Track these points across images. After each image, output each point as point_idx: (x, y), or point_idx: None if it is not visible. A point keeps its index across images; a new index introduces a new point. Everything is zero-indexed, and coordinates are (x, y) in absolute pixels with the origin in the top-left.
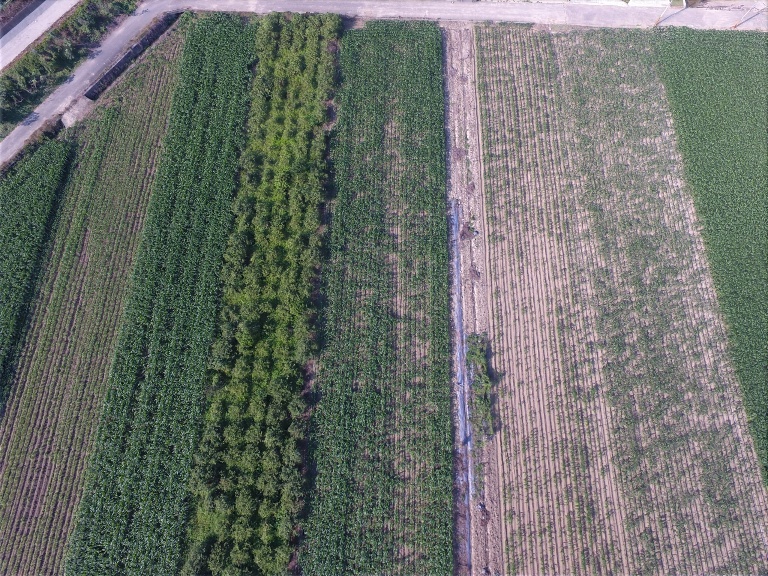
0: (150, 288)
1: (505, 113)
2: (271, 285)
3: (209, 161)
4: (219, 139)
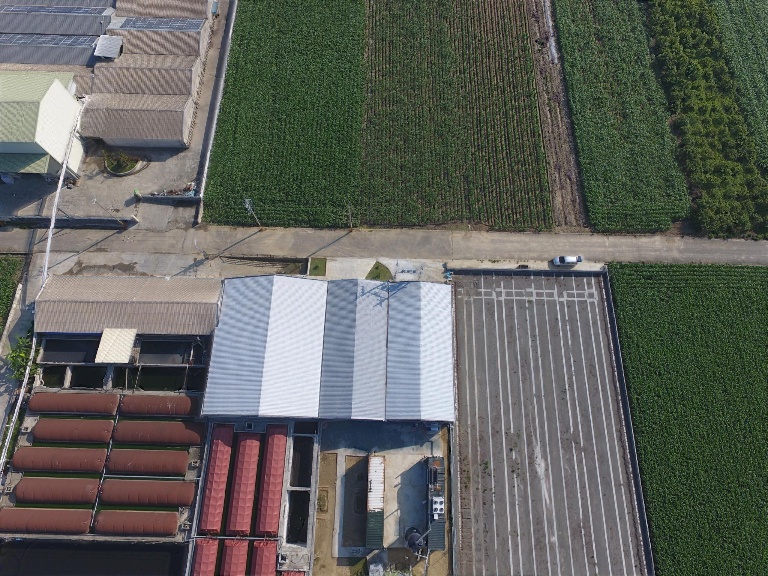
0: (757, 4)
1: (517, 132)
2: (678, 5)
3: (761, 84)
4: (761, 103)
